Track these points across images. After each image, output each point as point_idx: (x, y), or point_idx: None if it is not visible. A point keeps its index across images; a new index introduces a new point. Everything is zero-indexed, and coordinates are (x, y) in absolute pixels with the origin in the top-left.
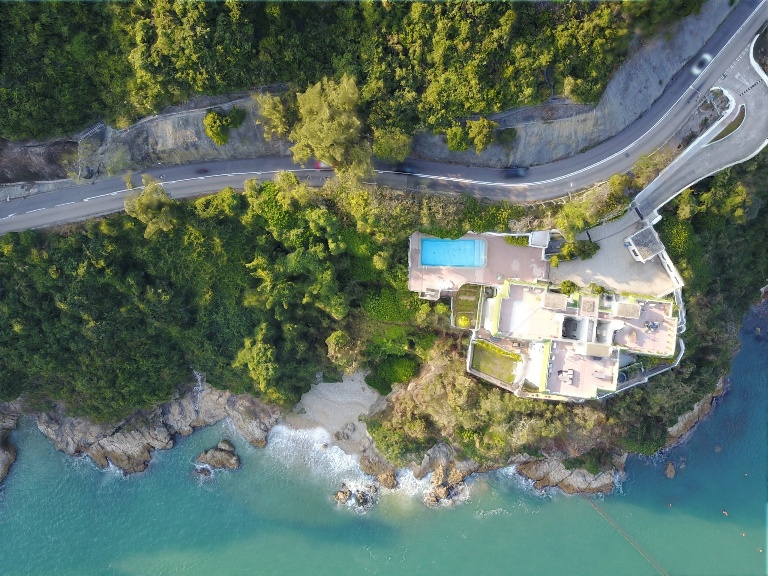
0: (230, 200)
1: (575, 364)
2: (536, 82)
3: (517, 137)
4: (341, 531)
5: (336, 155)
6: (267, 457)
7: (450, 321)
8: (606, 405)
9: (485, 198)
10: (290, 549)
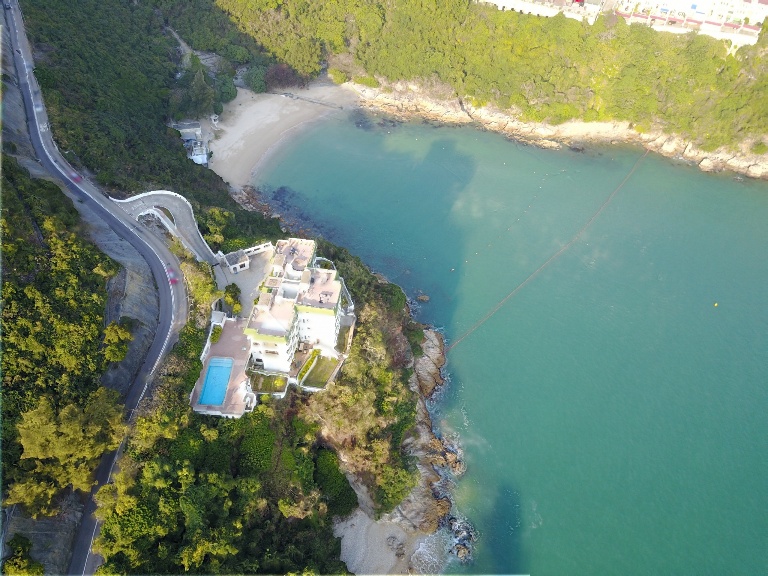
0: (108, 571)
1: (316, 294)
2: None
3: None
4: (498, 557)
5: (94, 429)
6: None
7: (278, 396)
8: None
9: (174, 346)
10: None
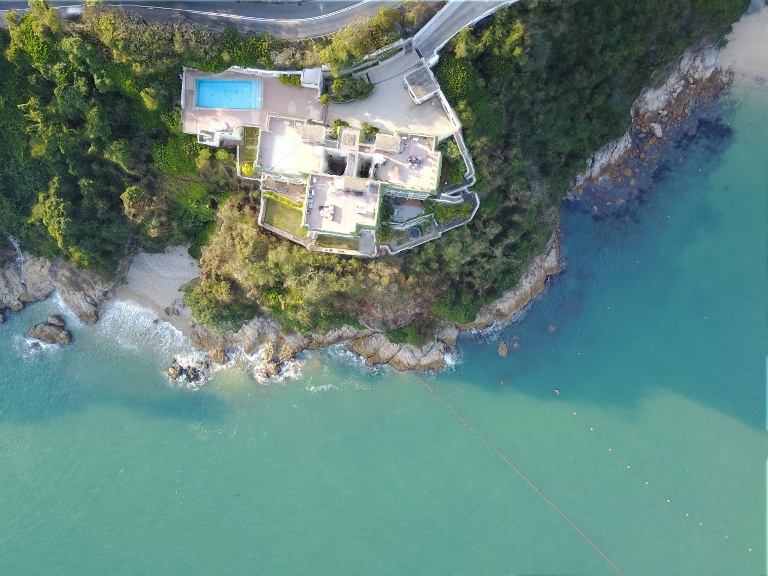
0: None
1: (337, 200)
2: None
3: None
4: (173, 407)
5: None
6: (99, 333)
7: (236, 170)
8: (405, 263)
9: (250, 31)
10: (123, 424)
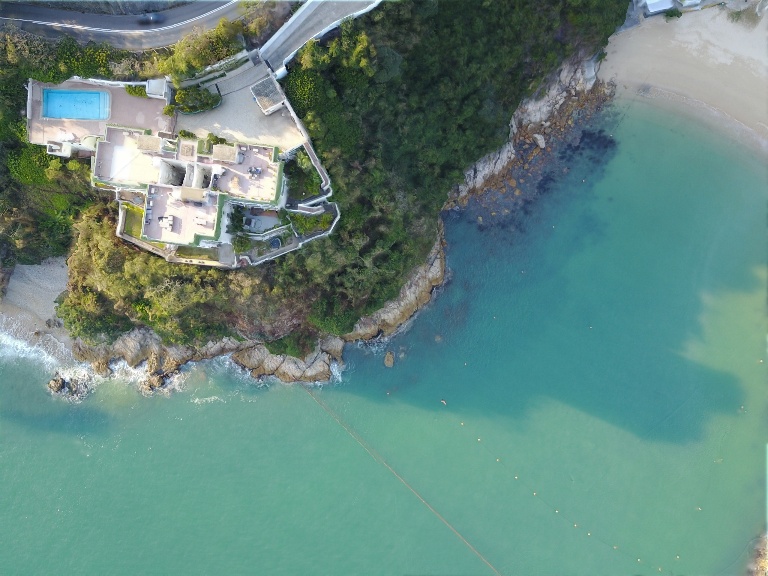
0: None
1: (177, 211)
2: None
3: None
4: (56, 420)
5: None
6: None
7: (90, 181)
8: (268, 274)
9: (90, 42)
10: (5, 439)
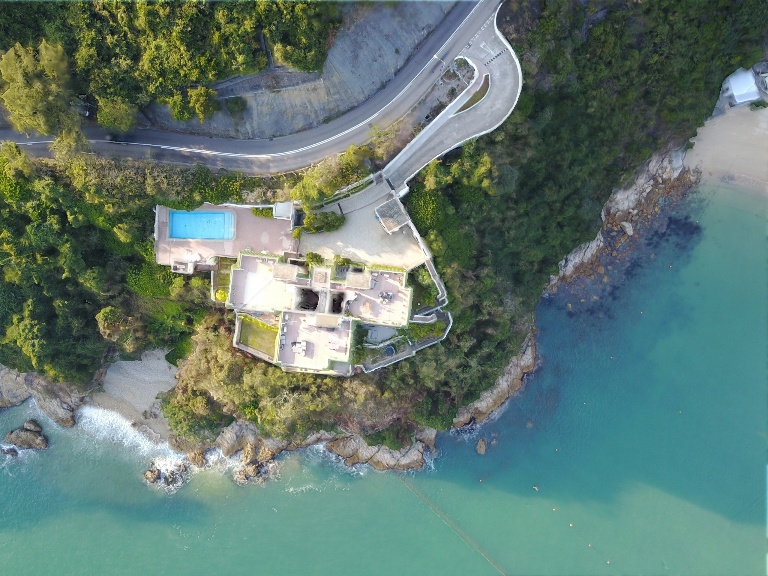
0: None
1: (309, 335)
2: (250, 49)
3: (249, 107)
4: (151, 510)
5: (41, 123)
6: (75, 437)
7: (210, 295)
8: (380, 379)
9: (222, 169)
10: (100, 529)
